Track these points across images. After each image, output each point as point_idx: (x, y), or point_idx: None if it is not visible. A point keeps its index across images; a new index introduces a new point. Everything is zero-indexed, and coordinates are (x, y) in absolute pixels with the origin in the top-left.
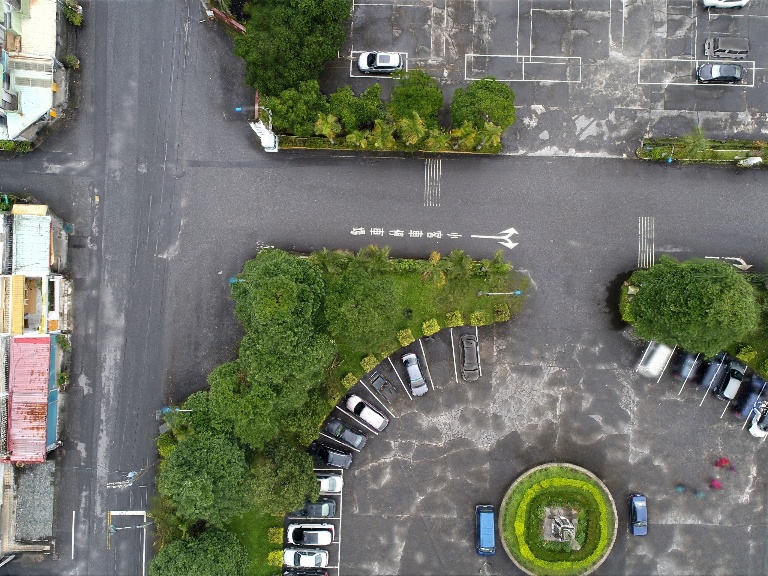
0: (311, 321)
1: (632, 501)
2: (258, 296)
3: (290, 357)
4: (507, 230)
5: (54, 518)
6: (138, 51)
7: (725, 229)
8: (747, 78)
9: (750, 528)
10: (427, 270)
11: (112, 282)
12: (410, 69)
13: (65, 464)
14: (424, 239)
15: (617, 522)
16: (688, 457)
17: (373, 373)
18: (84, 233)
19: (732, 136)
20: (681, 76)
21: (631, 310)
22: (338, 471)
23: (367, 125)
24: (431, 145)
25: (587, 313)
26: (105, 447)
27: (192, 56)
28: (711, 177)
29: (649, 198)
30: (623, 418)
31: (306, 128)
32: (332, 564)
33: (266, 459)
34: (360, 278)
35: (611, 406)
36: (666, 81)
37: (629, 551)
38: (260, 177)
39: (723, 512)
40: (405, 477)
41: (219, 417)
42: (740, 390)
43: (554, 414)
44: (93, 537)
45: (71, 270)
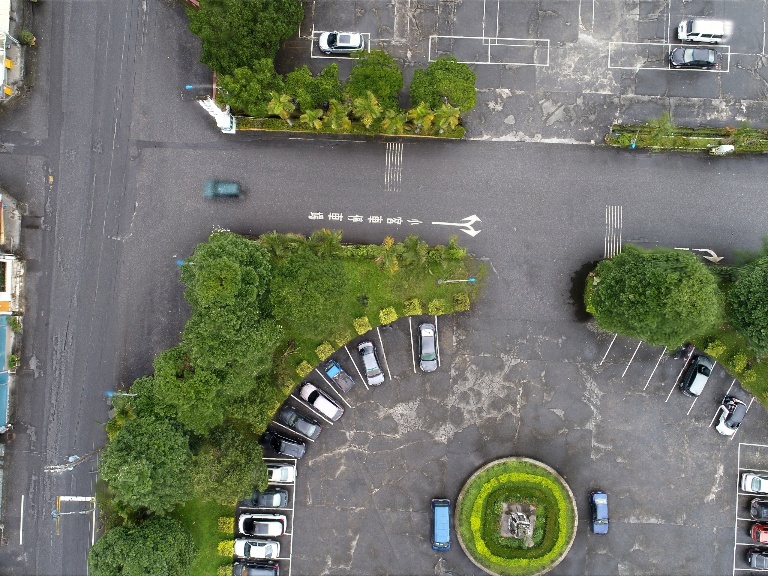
0: (257, 305)
1: (593, 498)
2: (201, 278)
3: (233, 341)
4: (469, 217)
5: (3, 502)
6: (95, 28)
7: (696, 219)
8: (722, 63)
9: (715, 529)
10: (380, 255)
11: (65, 264)
12: (372, 50)
13: (15, 448)
14: (384, 225)
15: (577, 520)
16: (652, 454)
17: (328, 361)
18: (38, 213)
19: (705, 123)
20: (653, 60)
21: (593, 301)
22: (292, 461)
23: (324, 106)
24: (387, 127)
25: (550, 304)
26: (55, 431)
27: (150, 34)
28: (682, 165)
29: (617, 186)
30: (586, 413)
31: (260, 108)
32: (284, 556)
33: (213, 446)
34: (308, 262)
35: (573, 400)
36: (637, 65)
37: (589, 550)
38: (217, 159)
39: (688, 512)
40: (360, 468)
41: (163, 402)
42: (708, 386)
43: (514, 407)
44: (42, 522)
45: (24, 251)
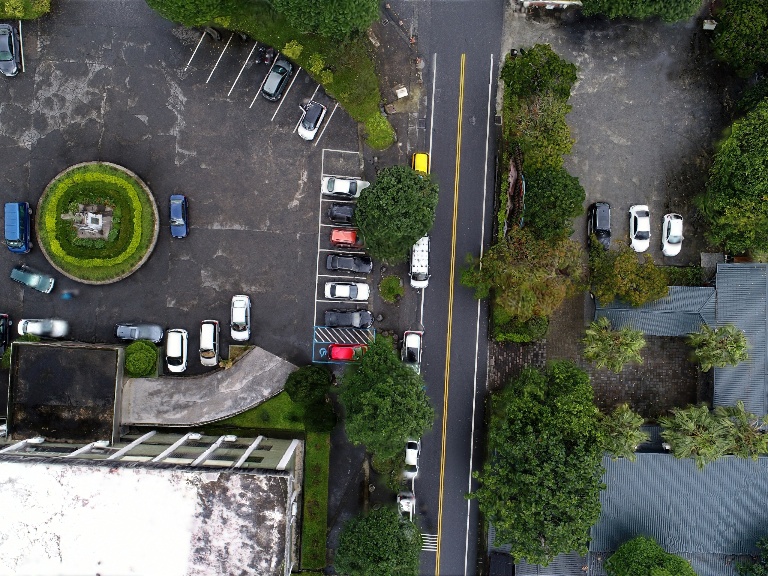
0: None
1: None
2: None
3: None
4: None
5: None
6: None
7: None
8: None
9: (299, 235)
10: None
11: None
12: None
13: None
14: None
15: (157, 223)
16: (237, 161)
17: None
18: None
19: None
20: None
21: None
22: None
23: None
24: None
25: (135, 9)
26: None
27: None
28: None
29: None
30: (170, 119)
31: None
32: None
33: None
34: None
35: (158, 106)
36: None
37: (172, 256)
38: None
39: (271, 218)
40: None
41: None
42: (292, 92)
43: (98, 113)
44: None
45: None
